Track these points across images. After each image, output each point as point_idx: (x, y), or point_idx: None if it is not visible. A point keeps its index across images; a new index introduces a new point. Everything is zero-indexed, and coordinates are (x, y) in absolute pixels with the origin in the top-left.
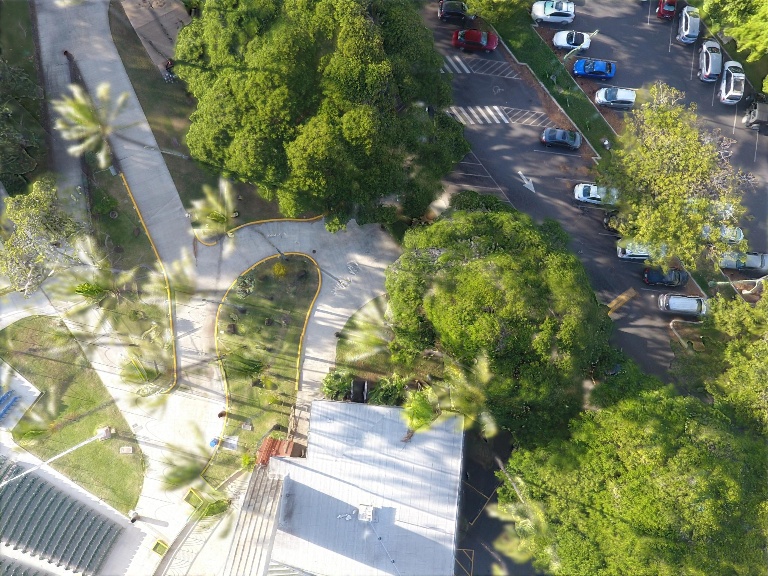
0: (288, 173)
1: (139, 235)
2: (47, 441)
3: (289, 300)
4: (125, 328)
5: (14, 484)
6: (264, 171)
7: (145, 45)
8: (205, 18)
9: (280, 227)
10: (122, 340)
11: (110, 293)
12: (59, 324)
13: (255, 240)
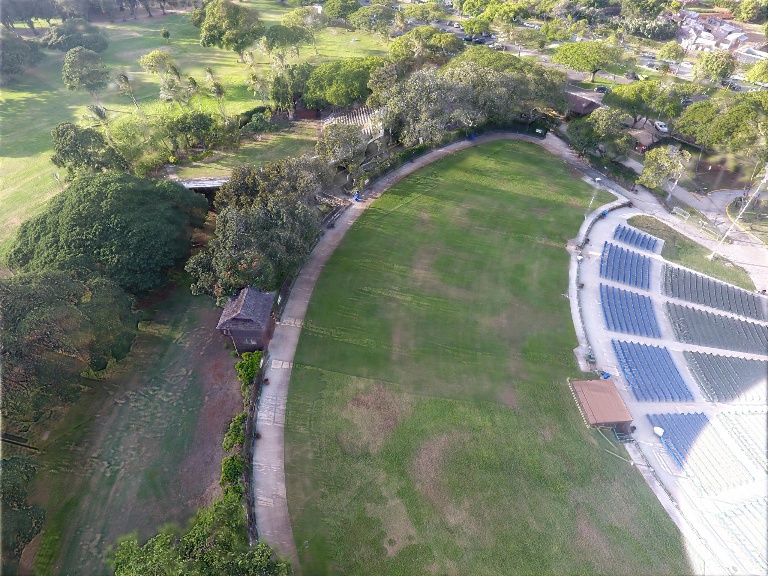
0: (765, 137)
1: (667, 193)
2: (680, 261)
3: (762, 211)
4: (688, 220)
5: (680, 274)
6: (754, 138)
7: (638, 140)
8: (688, 114)
9: (731, 191)
10: (690, 224)
11: (763, 133)
12: (654, 218)
13: (723, 195)
